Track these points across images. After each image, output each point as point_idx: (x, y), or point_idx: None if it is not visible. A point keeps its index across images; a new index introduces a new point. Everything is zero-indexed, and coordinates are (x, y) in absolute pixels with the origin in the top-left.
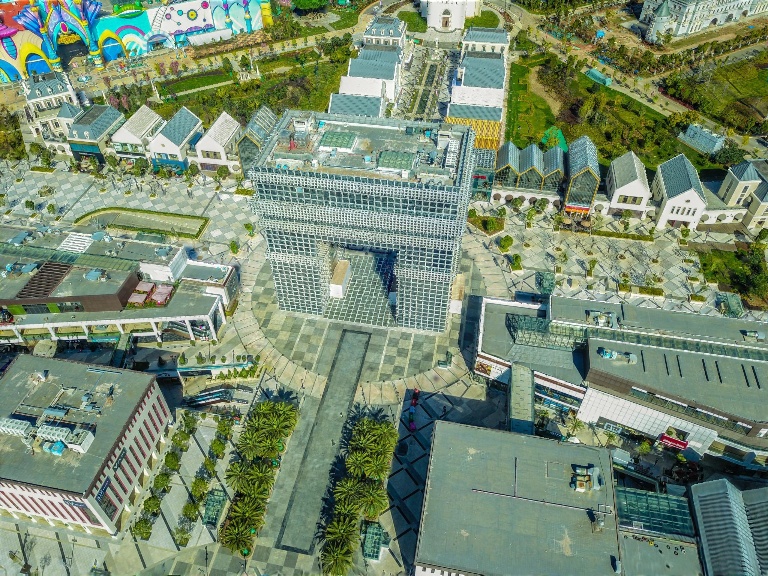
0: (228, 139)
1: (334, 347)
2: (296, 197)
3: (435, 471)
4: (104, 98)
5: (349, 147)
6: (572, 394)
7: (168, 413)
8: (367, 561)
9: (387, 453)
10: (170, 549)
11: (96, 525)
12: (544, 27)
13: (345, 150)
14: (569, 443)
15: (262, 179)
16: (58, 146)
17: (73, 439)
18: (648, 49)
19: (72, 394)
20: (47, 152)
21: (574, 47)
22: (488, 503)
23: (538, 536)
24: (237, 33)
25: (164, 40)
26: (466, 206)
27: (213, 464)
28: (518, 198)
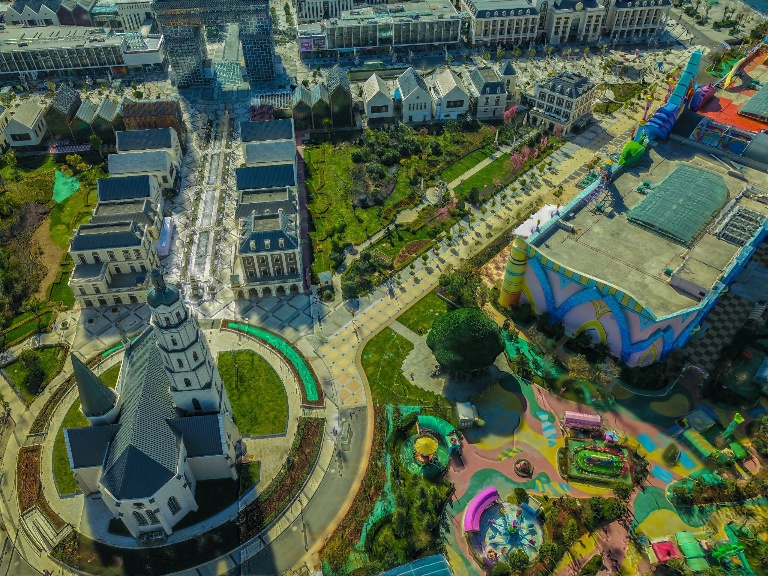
0: None
1: None
2: None
3: None
4: None
5: None
6: None
7: None
8: None
9: None
10: None
11: None
12: None
13: None
14: (130, 2)
15: None
16: None
17: None
18: None
19: None
20: None
21: None
22: None
23: None
24: None
25: None
26: None
27: None
28: None
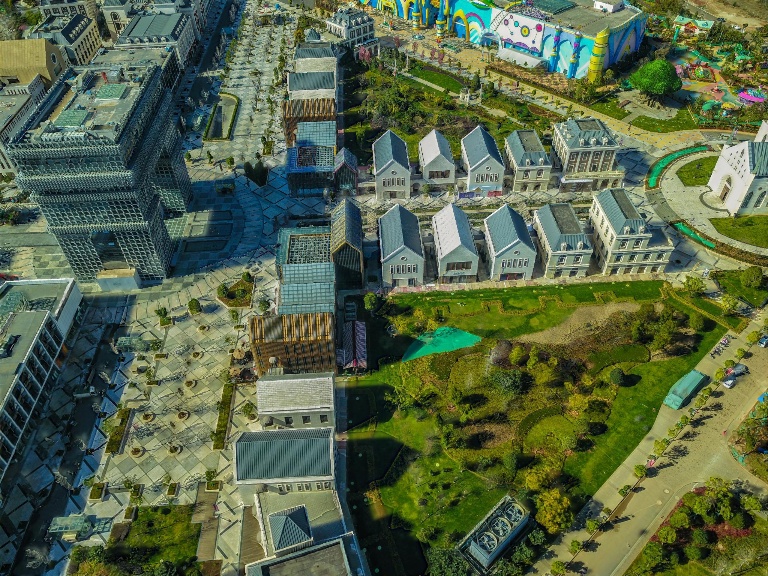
0: None
1: None
2: None
3: None
4: (379, 50)
5: (96, 96)
6: None
7: (12, 168)
8: None
9: None
10: None
11: None
12: None
13: None
14: None
15: None
16: None
17: None
18: None
19: None
20: None
21: None
22: None
23: None
24: (560, 71)
25: None
26: (46, 179)
27: None
28: (264, 302)
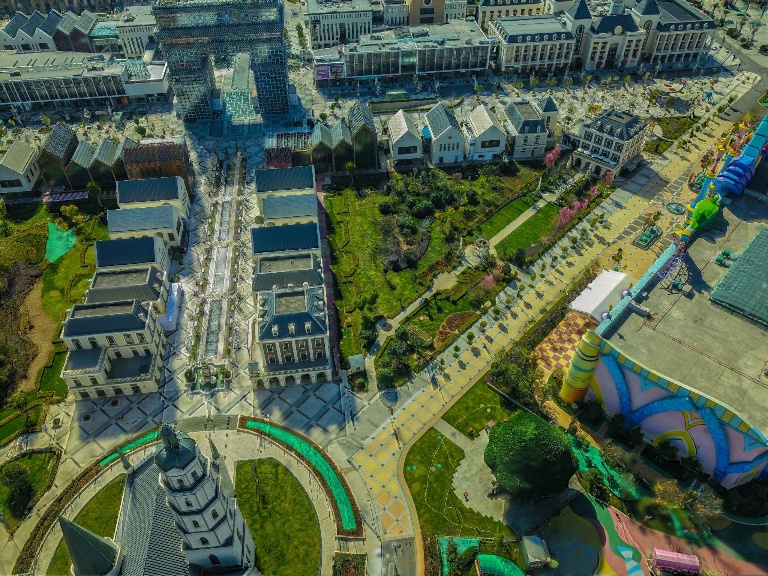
0: None
1: (251, 82)
2: None
3: None
4: None
5: None
6: None
7: None
8: None
9: None
10: None
11: None
12: None
13: None
14: (132, 25)
15: None
16: None
17: None
18: None
19: None
20: None
21: None
22: None
23: None
24: None
25: None
26: None
27: None
28: None
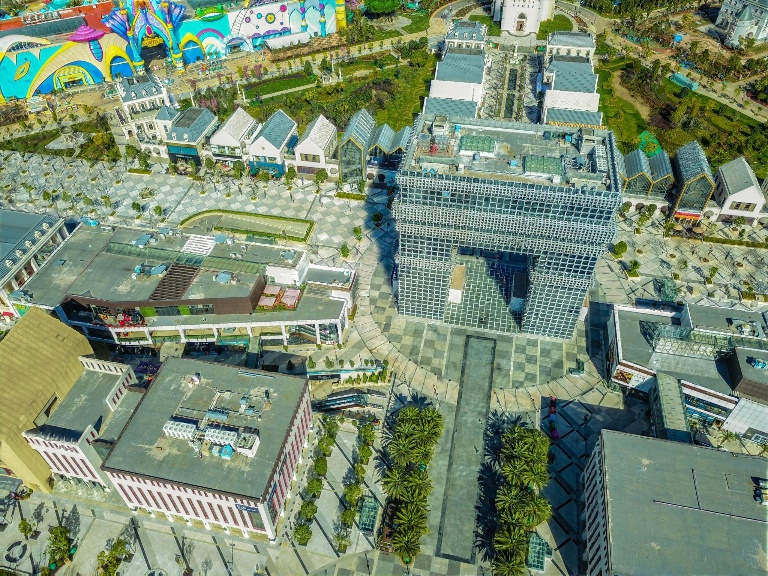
0: (327, 142)
1: (460, 353)
2: (441, 201)
3: (612, 481)
4: (192, 101)
5: (492, 151)
6: (721, 404)
7: (311, 417)
8: (531, 571)
9: (543, 462)
10: (330, 555)
11: (258, 530)
12: (619, 31)
13: (487, 154)
14: (744, 455)
15: (409, 183)
16: (154, 148)
17: (242, 443)
18: (729, 53)
19: (229, 397)
20: (144, 154)
21: (653, 51)
22: (673, 515)
23: (732, 550)
24: None
25: (242, 43)
26: None
27: (364, 470)
28: (626, 204)
